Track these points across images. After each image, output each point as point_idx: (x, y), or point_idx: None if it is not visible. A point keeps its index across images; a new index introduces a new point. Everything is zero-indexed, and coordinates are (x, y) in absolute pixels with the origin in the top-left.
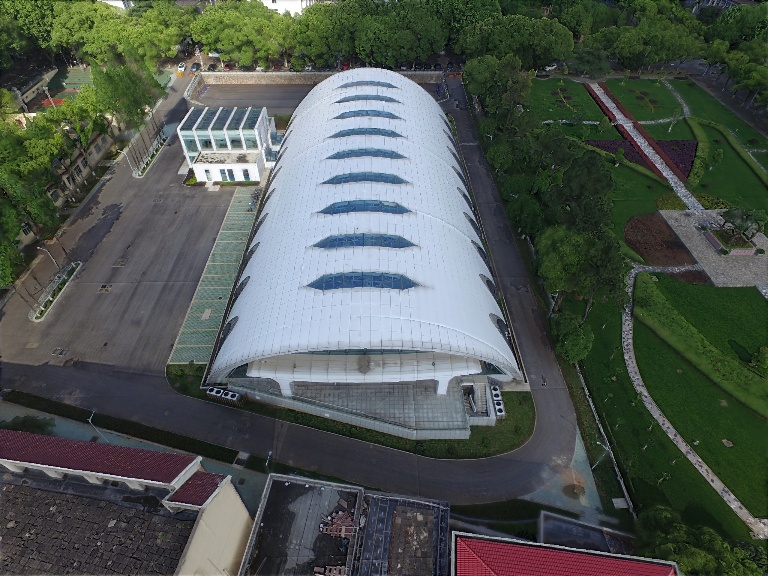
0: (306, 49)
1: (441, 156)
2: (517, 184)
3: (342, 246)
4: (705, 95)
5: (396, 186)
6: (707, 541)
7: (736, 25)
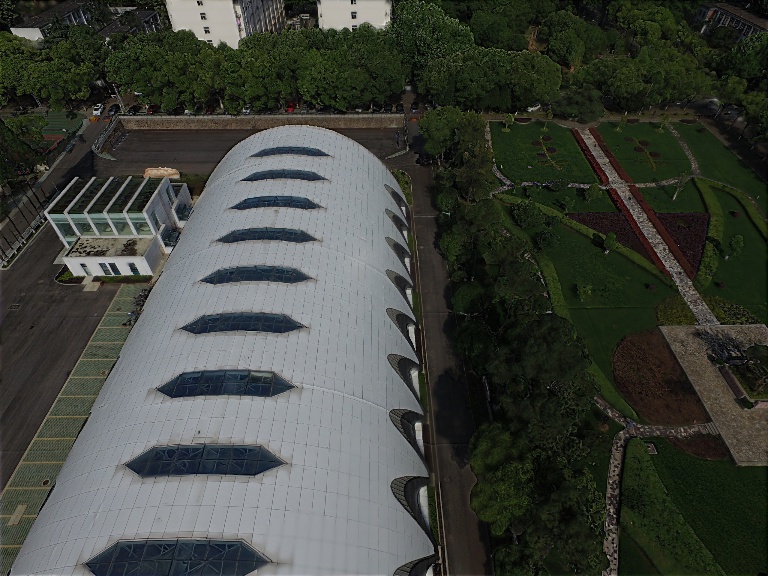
0: (238, 91)
1: (370, 260)
2: (470, 298)
3: (166, 472)
4: (718, 145)
5: (282, 337)
6: None
7: (755, 57)
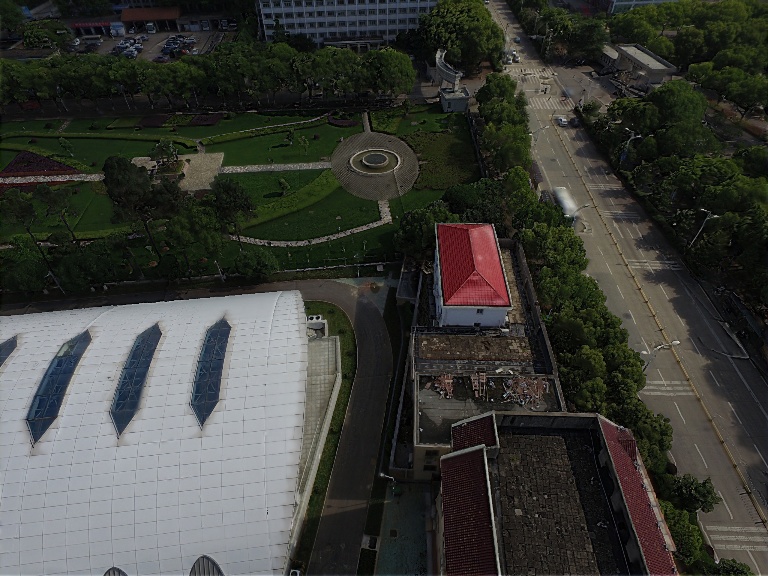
0: None
1: None
2: (33, 267)
3: (140, 392)
4: None
5: (21, 347)
6: (418, 216)
7: None
